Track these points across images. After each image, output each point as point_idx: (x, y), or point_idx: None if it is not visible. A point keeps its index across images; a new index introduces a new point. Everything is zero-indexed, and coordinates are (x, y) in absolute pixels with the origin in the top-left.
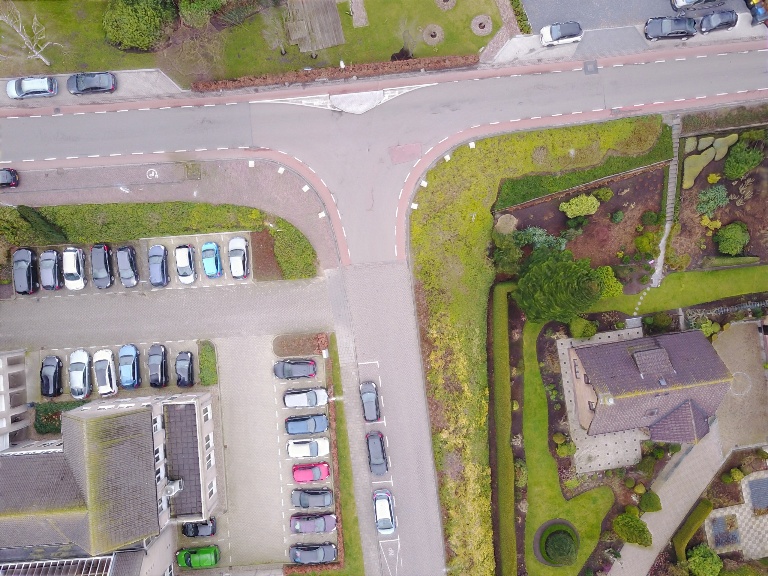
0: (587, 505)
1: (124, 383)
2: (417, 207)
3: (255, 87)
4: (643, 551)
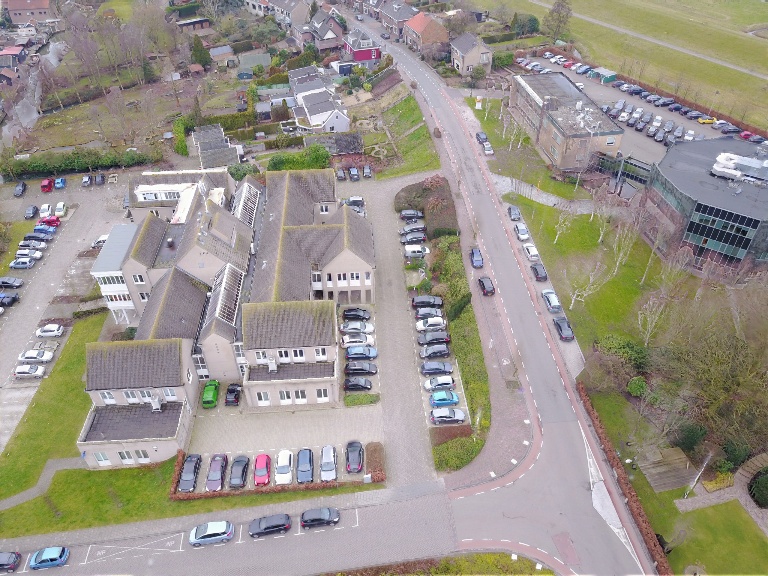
0: None
1: (350, 349)
2: (514, 559)
3: (592, 424)
4: None
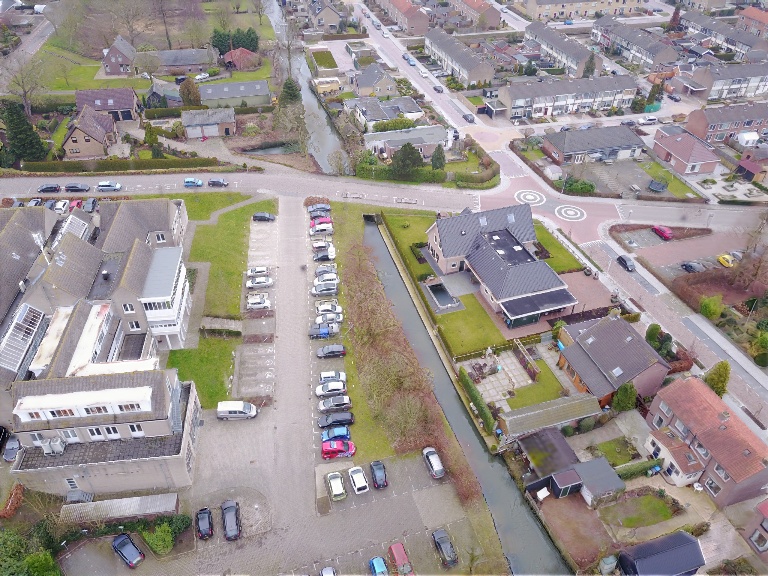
0: (145, 155)
1: None
2: None
3: None
4: (173, 144)
